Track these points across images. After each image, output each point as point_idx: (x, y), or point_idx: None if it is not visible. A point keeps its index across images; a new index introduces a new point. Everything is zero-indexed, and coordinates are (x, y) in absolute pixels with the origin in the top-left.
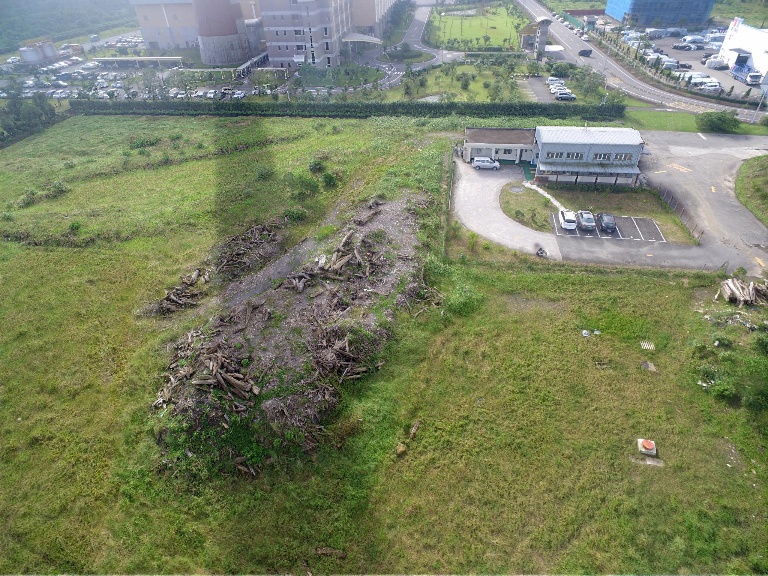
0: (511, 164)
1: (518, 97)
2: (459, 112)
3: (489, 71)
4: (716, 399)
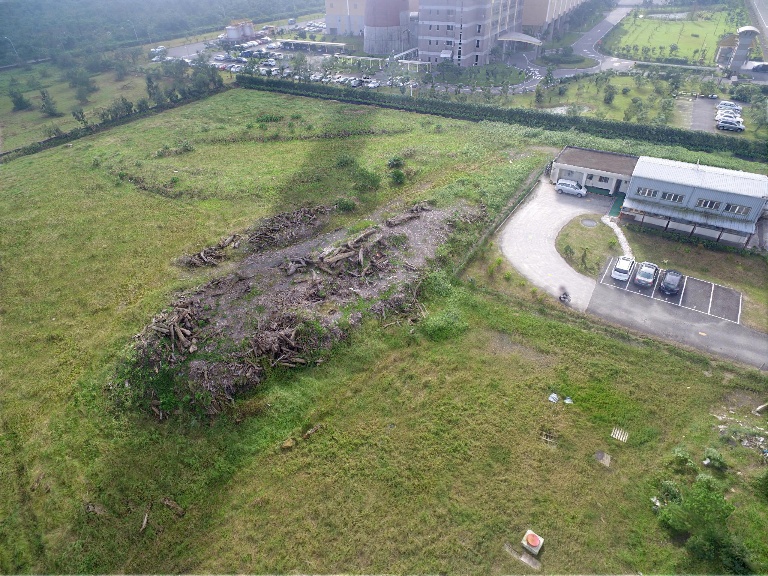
0: (603, 194)
1: (663, 119)
2: (581, 128)
3: (652, 86)
4: (659, 525)
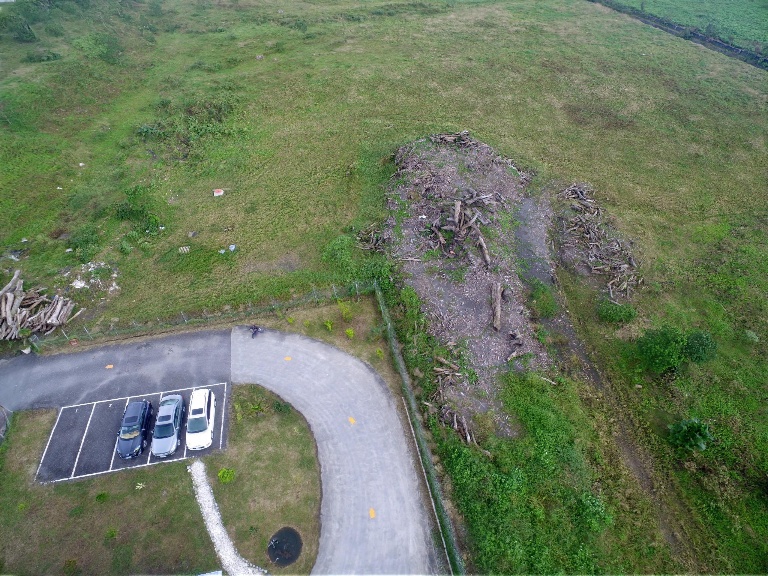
0: None
1: None
2: None
3: None
4: None
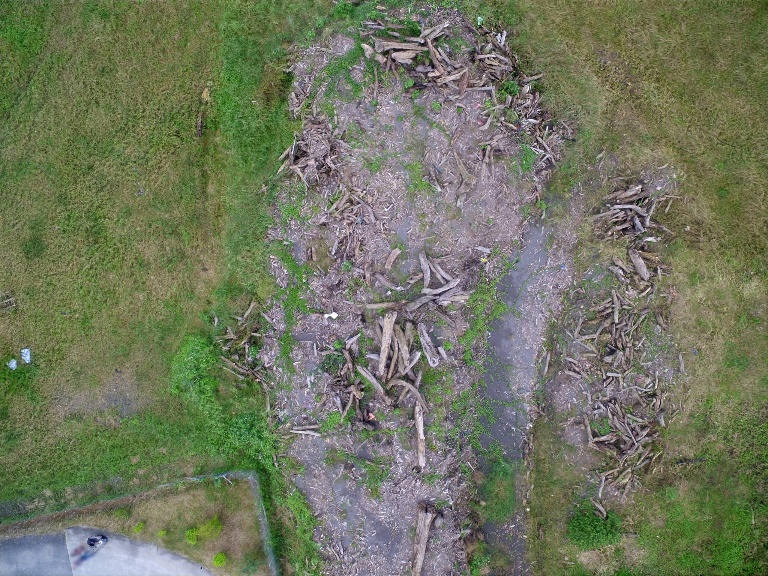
0: None
1: None
2: None
3: None
4: None
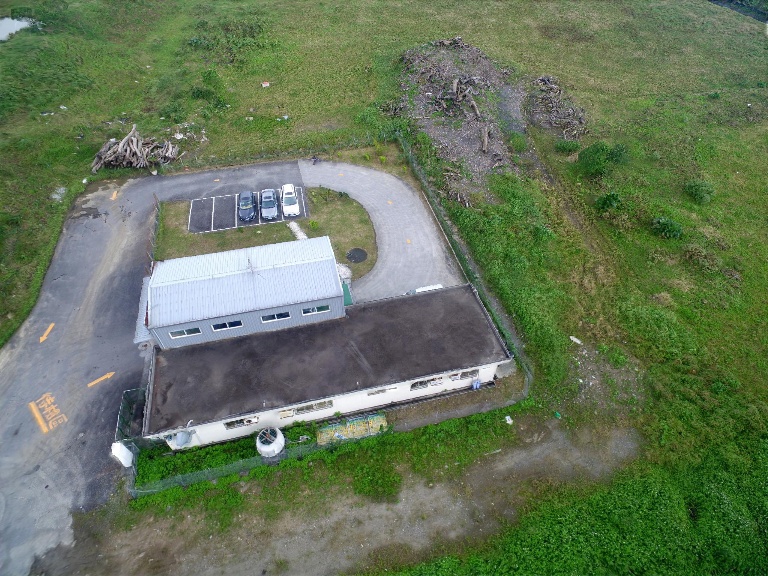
0: None
1: None
2: None
3: None
4: None
